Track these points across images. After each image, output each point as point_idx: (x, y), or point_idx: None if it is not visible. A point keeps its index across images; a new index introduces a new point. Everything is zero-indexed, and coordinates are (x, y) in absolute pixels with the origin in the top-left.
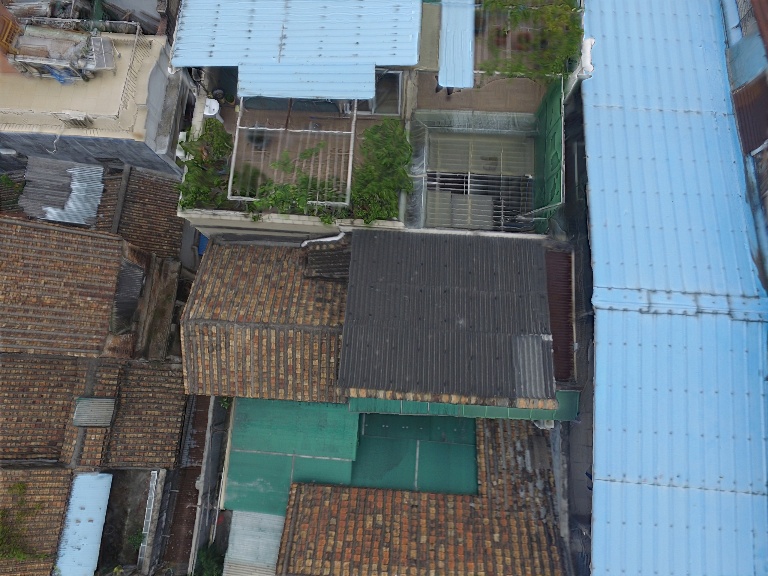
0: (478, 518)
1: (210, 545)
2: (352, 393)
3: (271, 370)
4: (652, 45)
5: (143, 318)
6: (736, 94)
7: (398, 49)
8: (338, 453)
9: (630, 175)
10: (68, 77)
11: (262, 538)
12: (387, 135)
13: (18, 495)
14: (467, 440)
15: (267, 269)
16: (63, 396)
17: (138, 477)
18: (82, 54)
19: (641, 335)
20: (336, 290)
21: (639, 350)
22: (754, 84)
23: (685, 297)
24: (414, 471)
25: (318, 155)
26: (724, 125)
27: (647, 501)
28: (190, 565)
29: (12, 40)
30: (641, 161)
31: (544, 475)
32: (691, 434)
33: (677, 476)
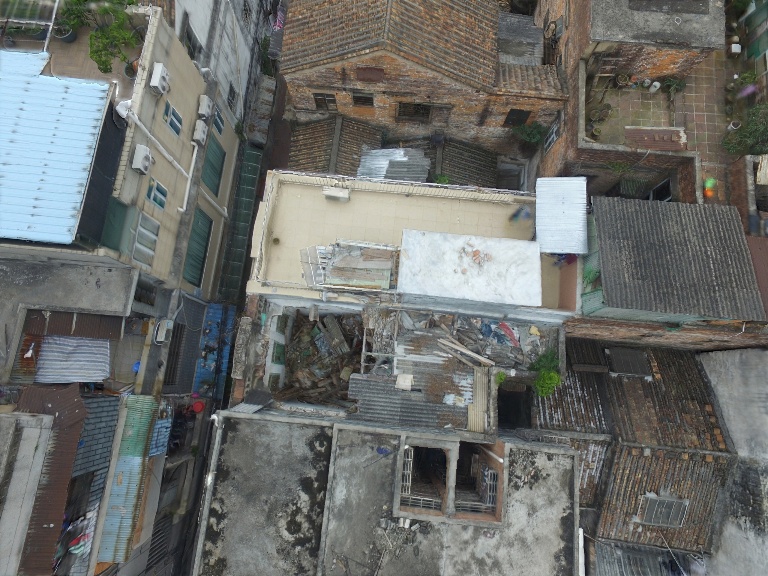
0: None
1: None
2: None
3: None
4: None
5: None
6: None
7: None
8: None
9: None
10: None
11: None
12: None
13: None
14: None
15: None
16: None
17: None
18: None
19: None
20: None
21: None
22: None
23: None
24: None
25: None
26: None
27: None
28: None
29: (396, 261)
30: None
31: None
32: None
33: None
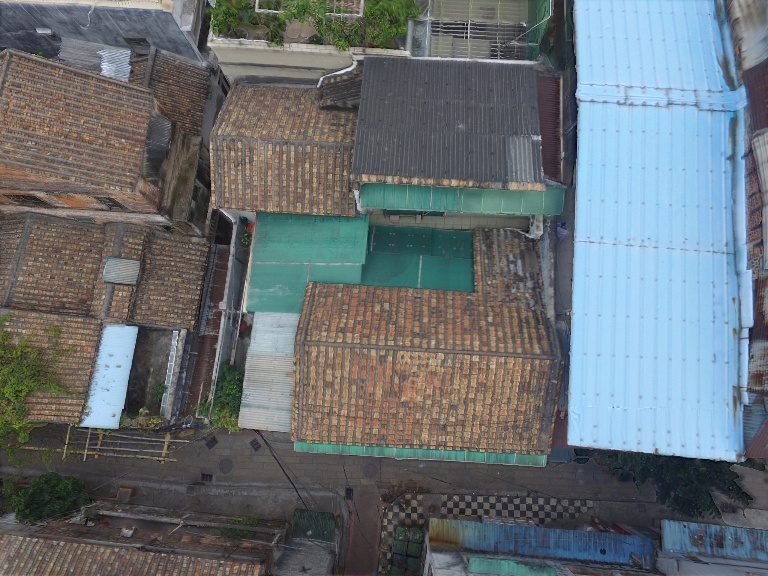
0: (474, 306)
1: (231, 364)
2: (364, 178)
3: (290, 184)
4: None
5: (168, 178)
6: None
7: None
8: (349, 259)
9: None
10: None
11: (281, 332)
12: None
13: (53, 337)
14: (465, 256)
15: (286, 103)
16: (92, 260)
17: (160, 341)
18: None
19: (618, 123)
20: (349, 117)
21: (616, 135)
22: None
23: (658, 91)
24: (417, 277)
25: None
26: None
27: (621, 259)
28: (214, 372)
29: None
30: None
31: (534, 278)
32: (661, 204)
33: (648, 238)
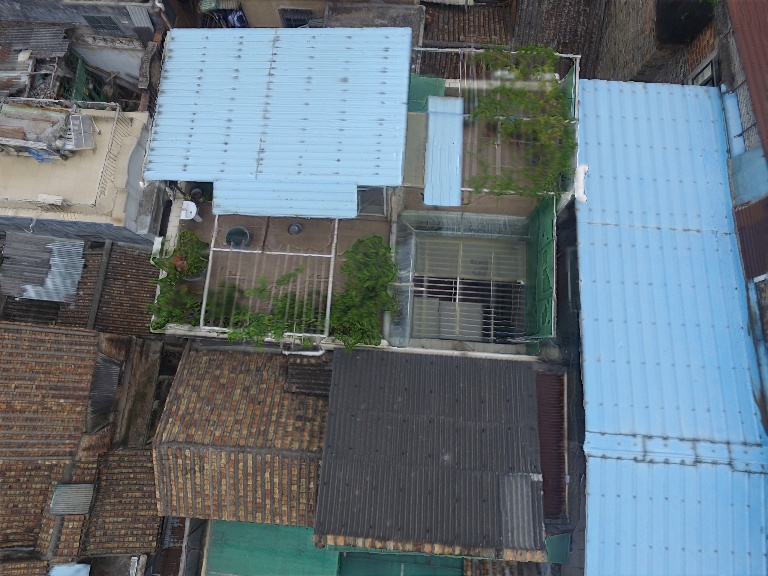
0: None
1: None
2: (329, 541)
3: (248, 494)
4: (650, 154)
5: (122, 407)
6: (738, 212)
7: (381, 168)
8: None
9: (626, 303)
10: (46, 156)
11: None
12: (370, 256)
13: None
14: (454, 563)
15: (246, 380)
16: (41, 479)
17: (119, 560)
18: (60, 134)
19: (636, 486)
20: (317, 407)
21: (634, 503)
22: (757, 207)
23: (683, 445)
24: None
25: (296, 281)
26: (725, 246)
27: None
28: None
29: None
30: (637, 287)
31: None
32: None
33: None
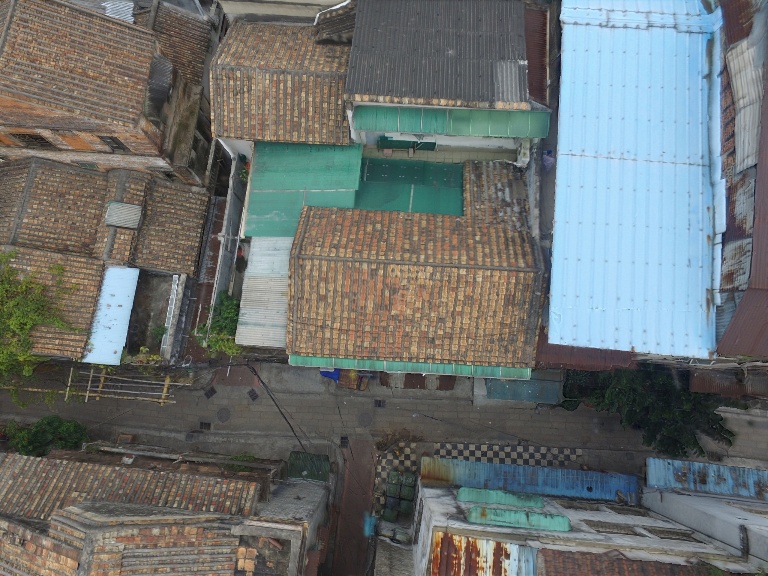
0: (463, 227)
1: (229, 295)
2: (357, 97)
3: (287, 113)
4: None
5: (170, 122)
6: None
7: None
8: (343, 185)
9: None
10: None
11: (277, 255)
12: None
13: (57, 275)
14: (455, 186)
15: (284, 38)
16: (95, 206)
17: (160, 286)
18: None
19: (600, 44)
20: (344, 50)
21: (598, 56)
22: None
23: (638, 15)
24: (409, 203)
25: None
26: None
27: (602, 171)
28: None
29: None
30: None
31: (521, 203)
32: (640, 120)
33: (627, 152)
